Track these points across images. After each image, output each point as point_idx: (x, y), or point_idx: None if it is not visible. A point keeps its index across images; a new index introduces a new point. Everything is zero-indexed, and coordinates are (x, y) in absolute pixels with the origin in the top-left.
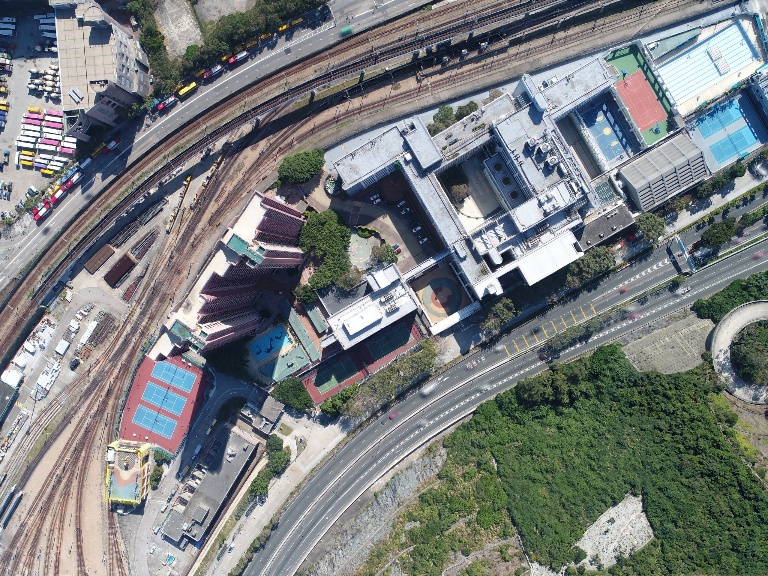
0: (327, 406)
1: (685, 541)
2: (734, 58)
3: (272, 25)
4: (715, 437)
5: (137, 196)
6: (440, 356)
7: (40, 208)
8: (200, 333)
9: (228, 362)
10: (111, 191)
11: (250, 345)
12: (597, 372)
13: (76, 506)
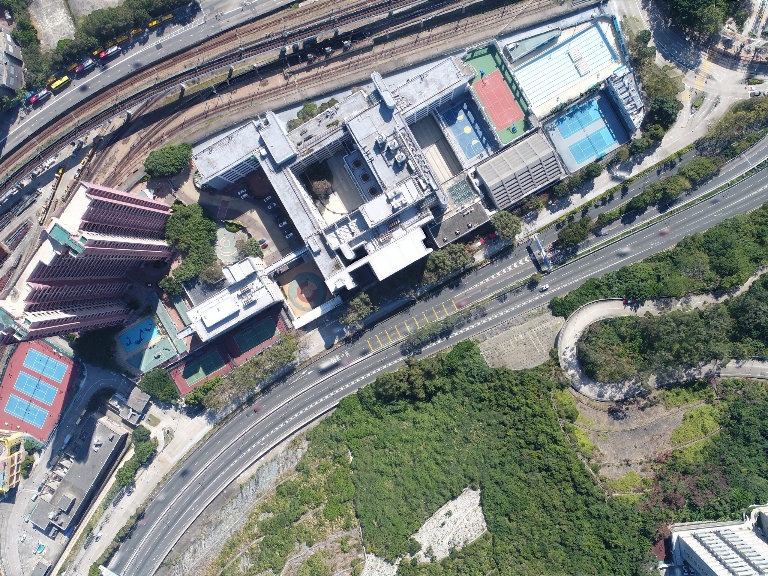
0: (189, 397)
1: (515, 534)
2: (594, 60)
3: (140, 20)
4: (553, 433)
5: (8, 187)
6: (305, 350)
7: None
8: (25, 321)
9: (93, 353)
10: None
11: (120, 336)
12: (453, 368)
13: None
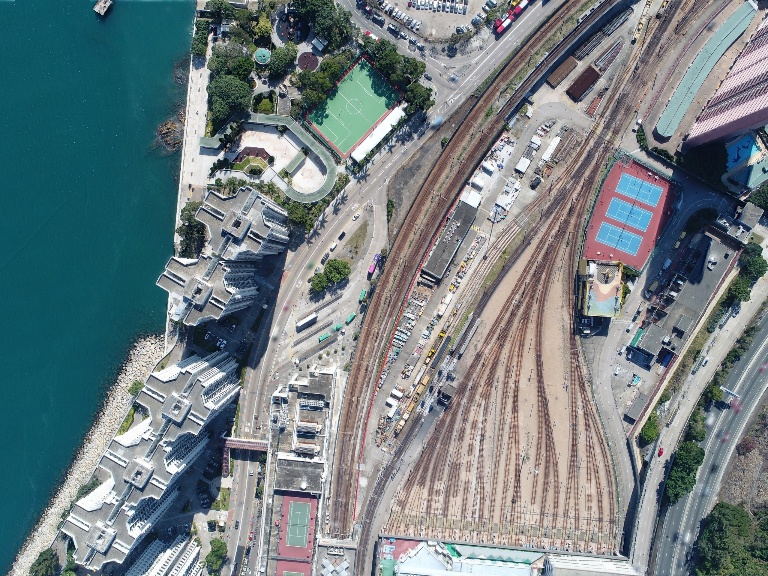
0: None
1: None
2: None
3: None
4: None
5: (613, 1)
6: None
7: (504, 19)
8: None
9: (715, 166)
10: (574, 2)
11: None
12: None
13: (536, 331)
